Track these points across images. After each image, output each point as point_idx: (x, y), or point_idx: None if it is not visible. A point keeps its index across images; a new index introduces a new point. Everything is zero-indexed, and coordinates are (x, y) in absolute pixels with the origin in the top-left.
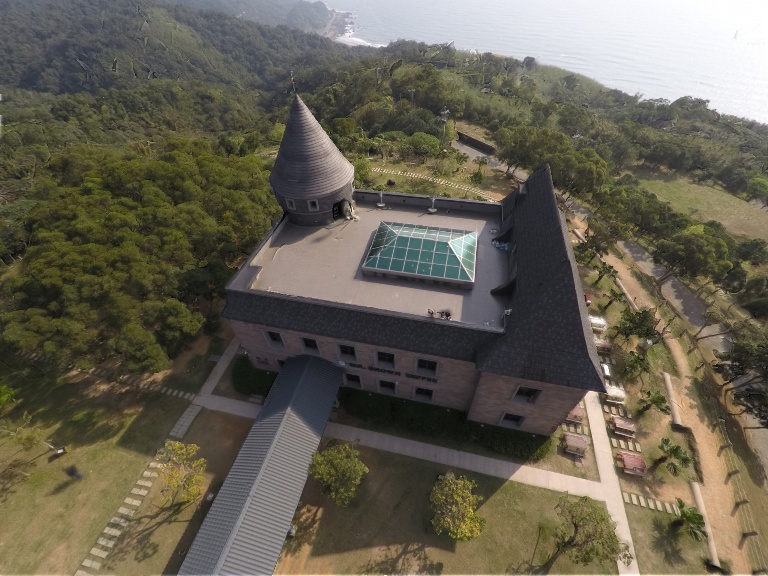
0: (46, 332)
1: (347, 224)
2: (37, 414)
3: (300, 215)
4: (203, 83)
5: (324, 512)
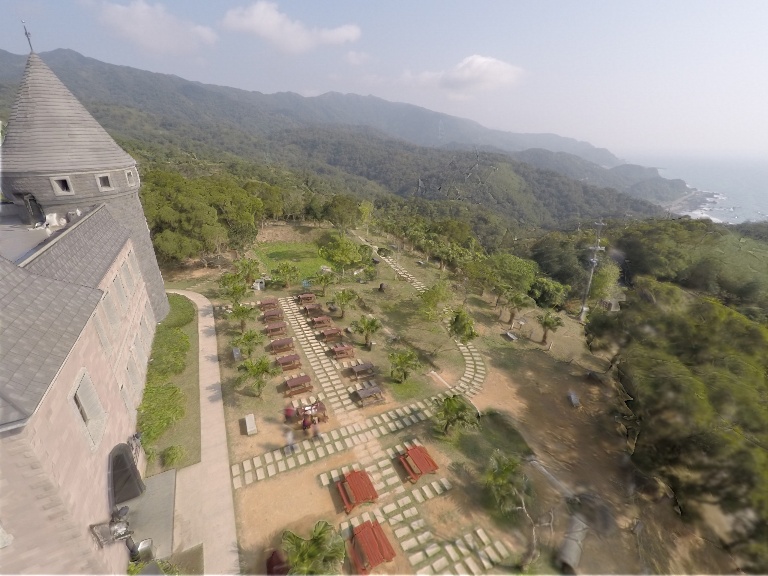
0: None
1: (21, 229)
2: None
3: None
4: None
5: None
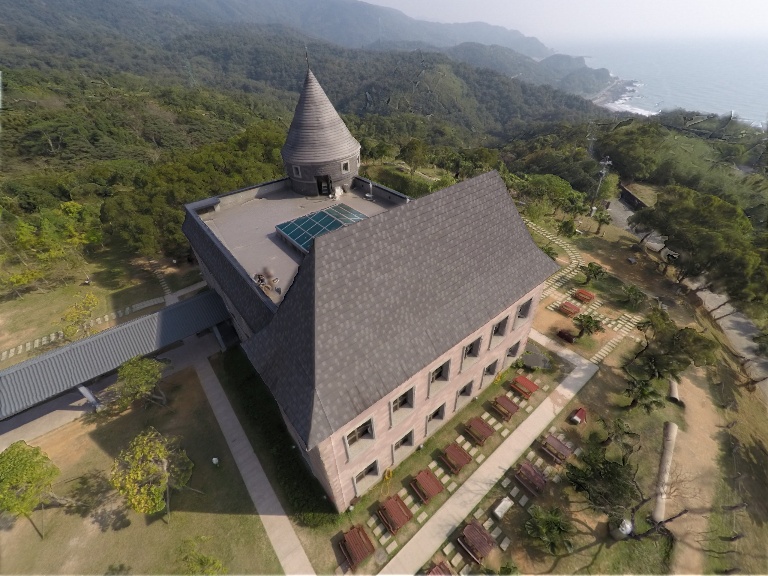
0: None
1: (324, 200)
2: (105, 259)
3: (293, 180)
4: None
5: (128, 414)
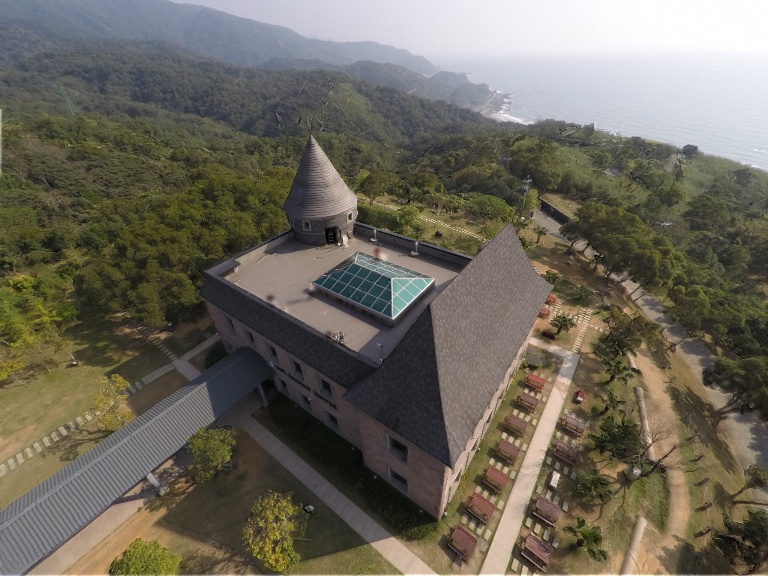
0: (104, 276)
1: (335, 249)
2: (82, 334)
3: (299, 233)
4: (357, 139)
5: (196, 489)
